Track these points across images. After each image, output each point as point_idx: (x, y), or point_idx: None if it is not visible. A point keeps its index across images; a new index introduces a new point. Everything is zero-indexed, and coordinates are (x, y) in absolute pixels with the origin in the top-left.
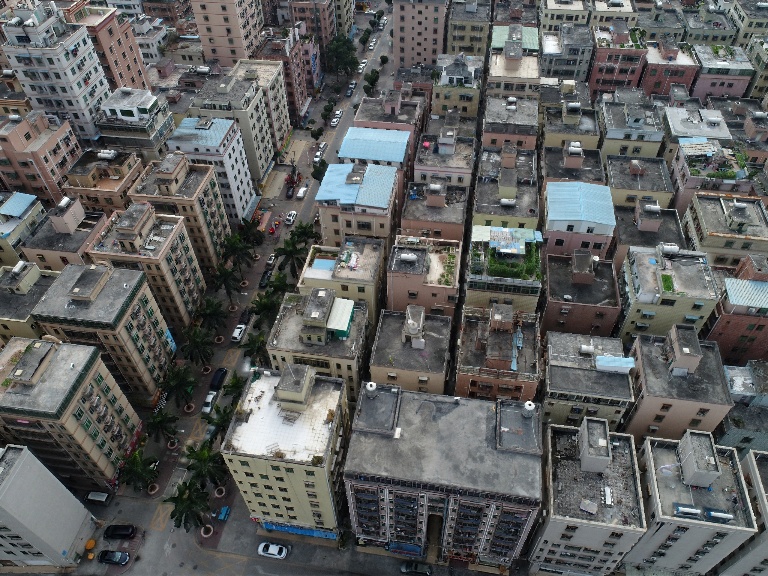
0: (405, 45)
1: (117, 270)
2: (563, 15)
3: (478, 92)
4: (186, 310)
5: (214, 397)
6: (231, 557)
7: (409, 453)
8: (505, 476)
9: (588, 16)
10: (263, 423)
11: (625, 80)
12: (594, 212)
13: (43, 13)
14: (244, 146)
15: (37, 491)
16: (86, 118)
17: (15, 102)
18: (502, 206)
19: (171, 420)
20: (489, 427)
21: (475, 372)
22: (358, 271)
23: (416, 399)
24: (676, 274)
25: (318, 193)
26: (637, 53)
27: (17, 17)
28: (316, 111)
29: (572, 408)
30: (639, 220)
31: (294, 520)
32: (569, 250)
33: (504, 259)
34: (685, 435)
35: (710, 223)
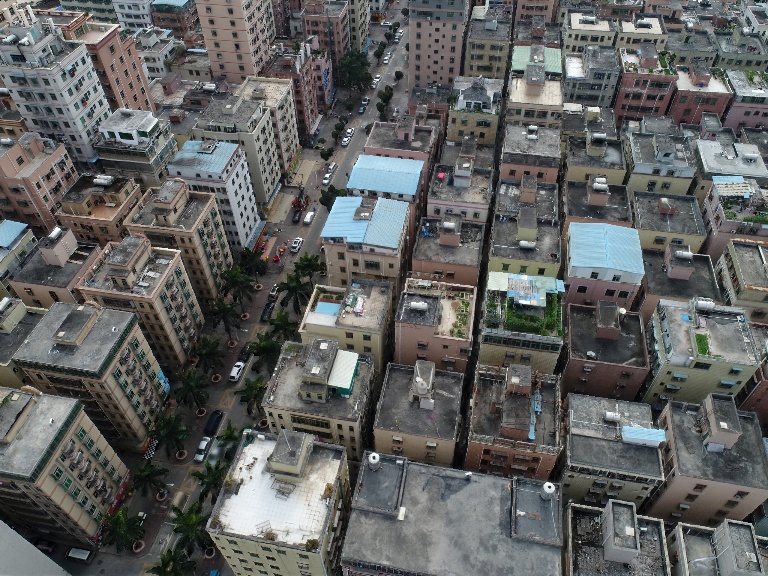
0: (421, 63)
1: (106, 311)
2: (588, 36)
3: (497, 118)
4: (182, 348)
5: (208, 443)
6: None
7: (414, 538)
8: (520, 571)
9: (614, 37)
10: (254, 496)
11: (653, 107)
12: (621, 259)
13: (40, 30)
14: (249, 169)
15: (8, 561)
16: (83, 140)
17: (10, 122)
18: (521, 249)
19: (160, 472)
20: (503, 510)
21: (489, 441)
22: (364, 317)
23: (423, 473)
24: (711, 334)
25: (324, 229)
26: (667, 79)
27: (13, 35)
28: (327, 129)
29: (594, 482)
30: (669, 267)
31: None
32: (592, 297)
33: (522, 310)
34: (722, 525)
35: (748, 274)
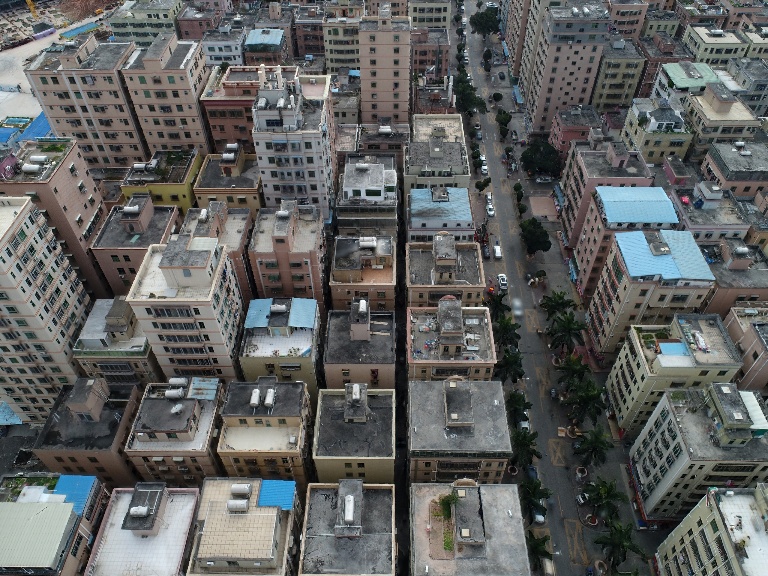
0: (554, 85)
1: (471, 383)
2: (723, 49)
3: (691, 137)
4: None
5: None
6: None
7: None
8: None
9: (747, 48)
10: (766, 556)
11: None
12: None
13: (287, 91)
14: None
15: None
16: (326, 202)
17: (245, 190)
18: None
19: None
20: None
21: None
22: (713, 353)
23: None
24: None
25: (630, 268)
26: None
27: (263, 98)
28: None
29: None
30: None
31: None
32: None
33: None
34: None
35: None
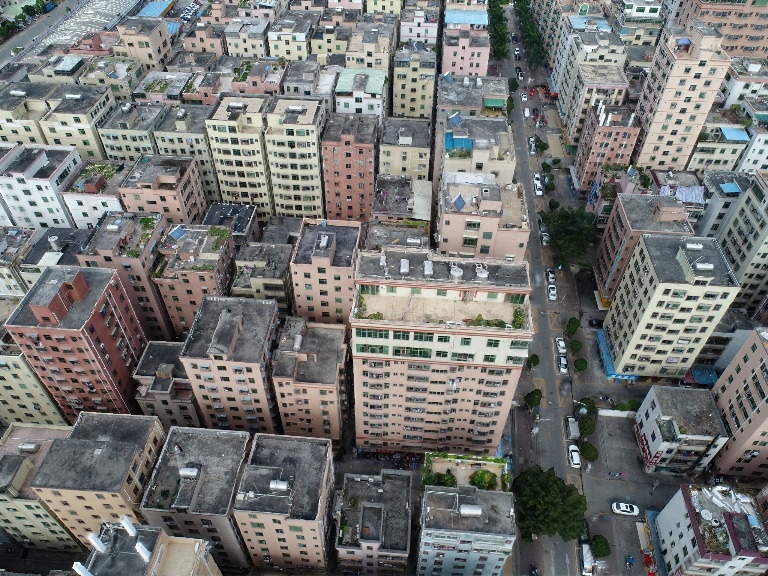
0: None
1: None
2: None
3: None
4: None
5: None
6: None
7: None
8: None
9: None
10: None
11: None
12: None
13: None
14: None
15: None
16: None
17: None
18: None
19: None
20: None
21: None
22: None
23: None
24: None
25: None
26: None
27: None
28: (567, 197)
29: None
30: None
31: None
32: None
33: None
34: None
35: None
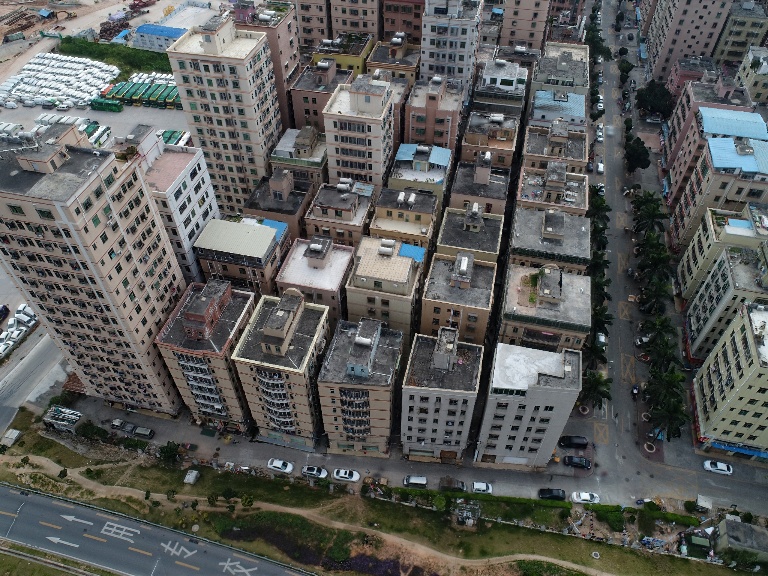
0: (678, 37)
1: (566, 216)
2: None
3: None
4: None
5: (605, 338)
6: (680, 470)
7: None
8: None
9: None
10: None
11: None
12: None
13: None
14: None
15: None
16: (468, 85)
17: (406, 67)
18: None
19: (601, 351)
20: None
21: None
22: None
23: None
24: None
25: (715, 161)
26: None
27: None
28: None
29: None
30: None
31: (750, 441)
32: None
33: None
34: None
35: None
